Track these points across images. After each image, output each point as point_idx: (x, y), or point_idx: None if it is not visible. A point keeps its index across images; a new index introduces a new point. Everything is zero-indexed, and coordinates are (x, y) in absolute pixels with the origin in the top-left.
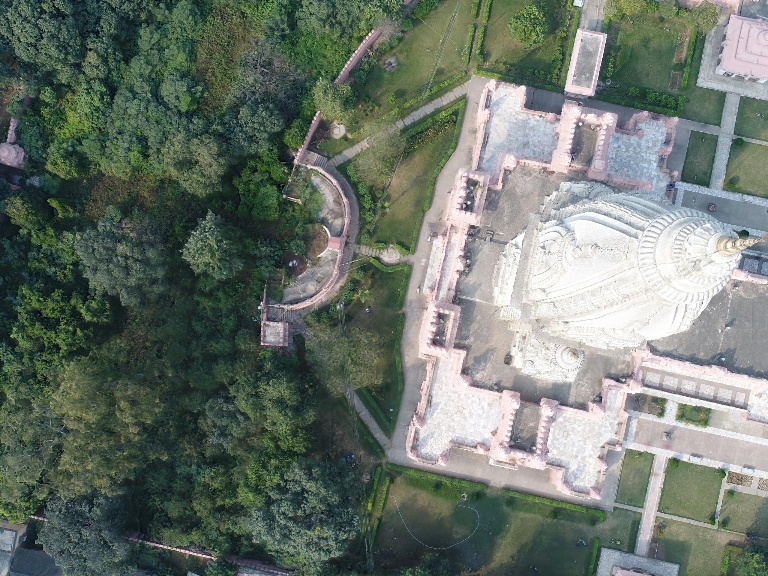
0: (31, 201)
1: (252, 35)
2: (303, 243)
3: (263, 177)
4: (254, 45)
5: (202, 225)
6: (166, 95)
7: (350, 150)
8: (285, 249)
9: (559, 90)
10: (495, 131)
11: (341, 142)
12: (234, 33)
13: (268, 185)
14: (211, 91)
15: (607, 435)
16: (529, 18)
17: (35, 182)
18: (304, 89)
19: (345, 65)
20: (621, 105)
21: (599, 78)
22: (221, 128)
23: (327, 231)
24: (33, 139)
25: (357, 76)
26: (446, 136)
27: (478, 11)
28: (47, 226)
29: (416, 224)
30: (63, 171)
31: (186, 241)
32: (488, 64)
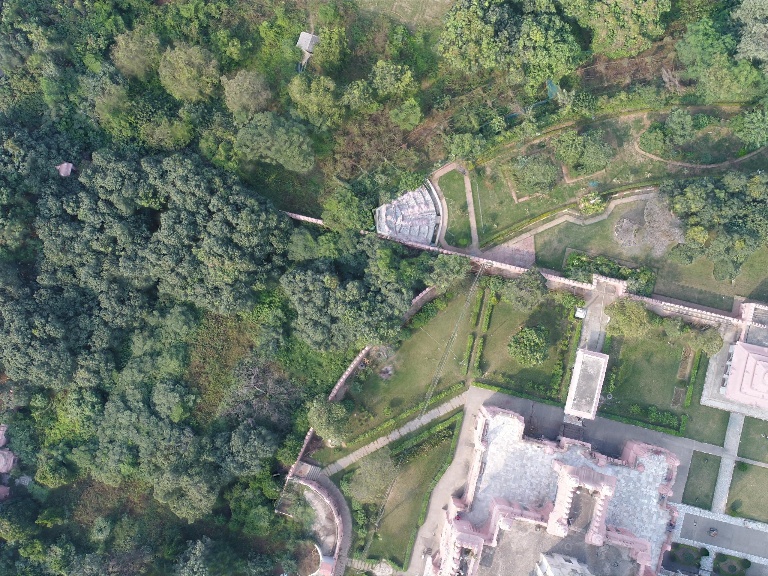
0: (19, 520)
1: (247, 338)
2: (294, 563)
3: (255, 493)
4: (248, 351)
5: (190, 564)
6: (158, 404)
7: (344, 459)
8: (276, 562)
9: (559, 406)
10: (492, 460)
11: (335, 453)
12: (229, 336)
13: (259, 506)
14: (204, 397)
15: None
16: (529, 346)
17: (24, 482)
18: (298, 399)
19: (340, 379)
20: (622, 422)
21: (600, 393)
22: (212, 458)
23: (319, 551)
24: (23, 444)
25: (352, 388)
26: (442, 448)
27: (478, 319)
28: (35, 536)
29: (410, 540)
30: (52, 484)
31: (175, 562)
32: (487, 374)
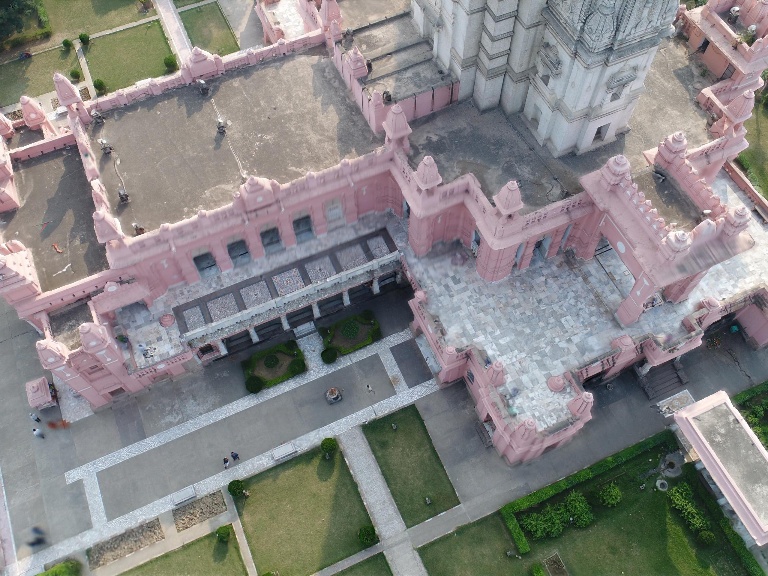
0: None
1: None
2: None
3: None
4: None
5: None
6: None
7: None
8: None
9: None
10: (761, 235)
11: None
12: None
13: None
14: None
15: (284, 8)
16: None
17: None
18: None
19: None
20: None
21: (683, 479)
22: None
23: None
24: None
25: None
26: None
27: None
28: None
29: None
30: None
31: None
32: None
